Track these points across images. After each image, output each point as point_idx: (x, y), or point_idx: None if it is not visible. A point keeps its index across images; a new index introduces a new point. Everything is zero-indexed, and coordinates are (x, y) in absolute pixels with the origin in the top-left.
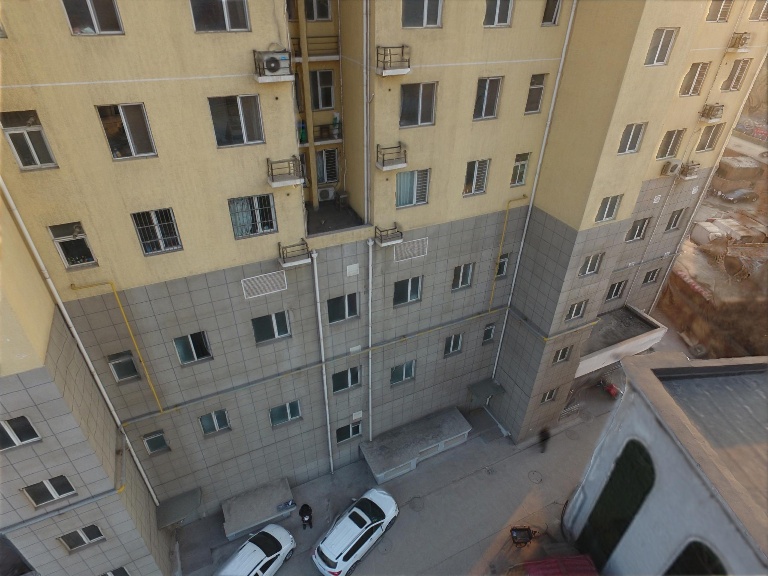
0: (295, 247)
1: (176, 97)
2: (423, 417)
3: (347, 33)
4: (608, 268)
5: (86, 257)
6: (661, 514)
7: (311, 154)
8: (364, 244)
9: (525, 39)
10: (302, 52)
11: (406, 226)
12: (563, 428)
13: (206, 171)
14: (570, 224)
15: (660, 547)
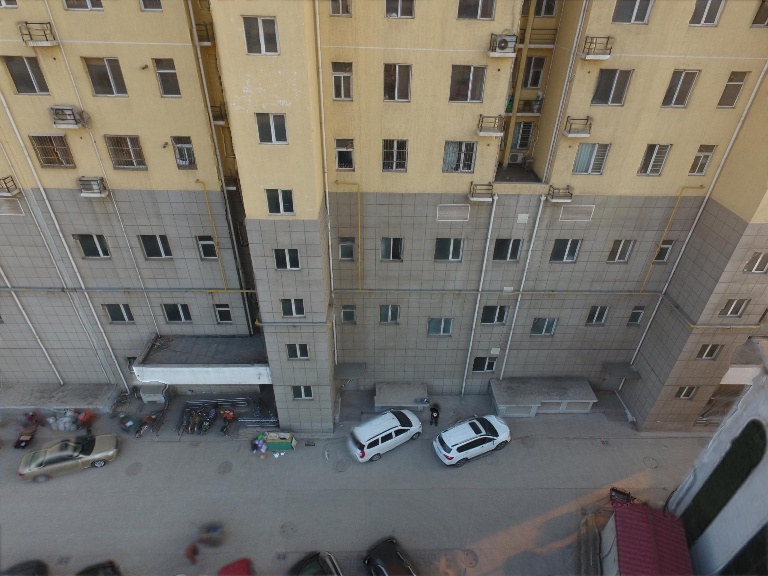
0: (483, 186)
1: (433, 62)
2: (553, 377)
3: (565, 27)
4: None
5: (349, 165)
6: (762, 485)
7: (512, 122)
8: (537, 198)
9: (730, 38)
10: (525, 40)
11: (577, 191)
12: (696, 435)
13: (437, 117)
14: (742, 216)
15: (753, 515)
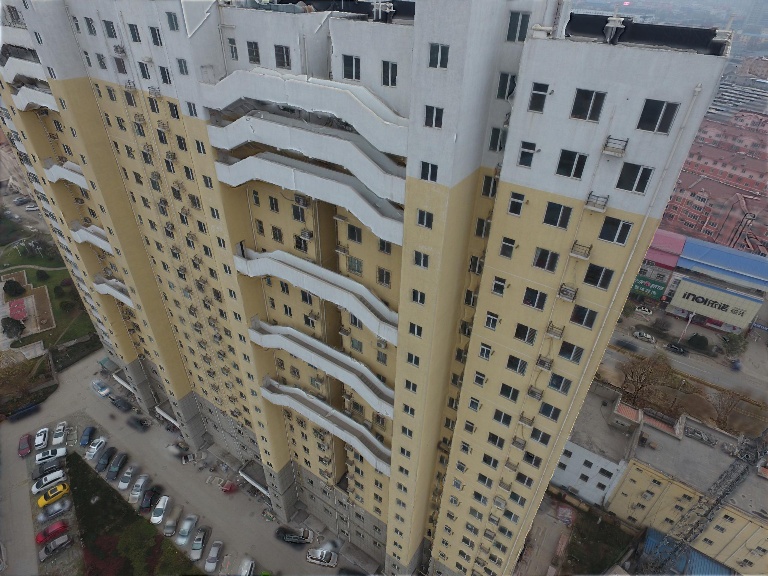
0: (328, 486)
1: (313, 452)
2: (368, 555)
3: None
4: (403, 575)
5: None
6: None
7: None
8: None
9: None
10: None
11: (358, 504)
12: None
13: None
14: None
15: None
